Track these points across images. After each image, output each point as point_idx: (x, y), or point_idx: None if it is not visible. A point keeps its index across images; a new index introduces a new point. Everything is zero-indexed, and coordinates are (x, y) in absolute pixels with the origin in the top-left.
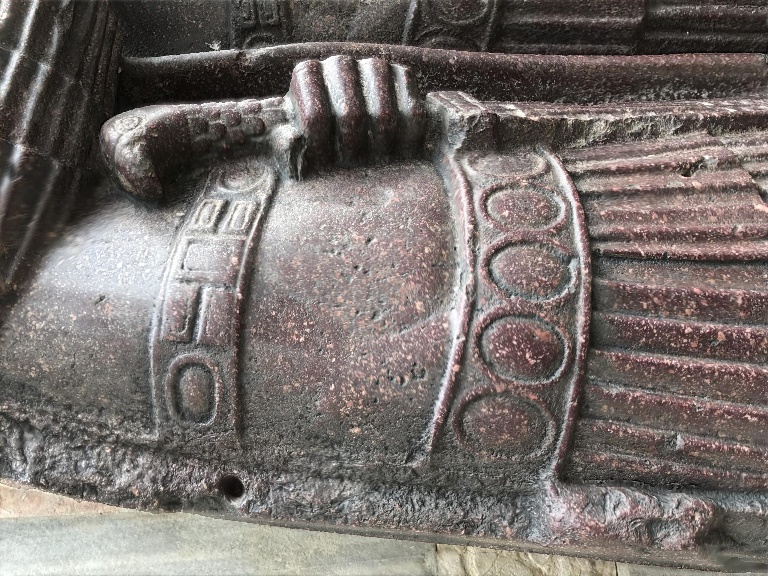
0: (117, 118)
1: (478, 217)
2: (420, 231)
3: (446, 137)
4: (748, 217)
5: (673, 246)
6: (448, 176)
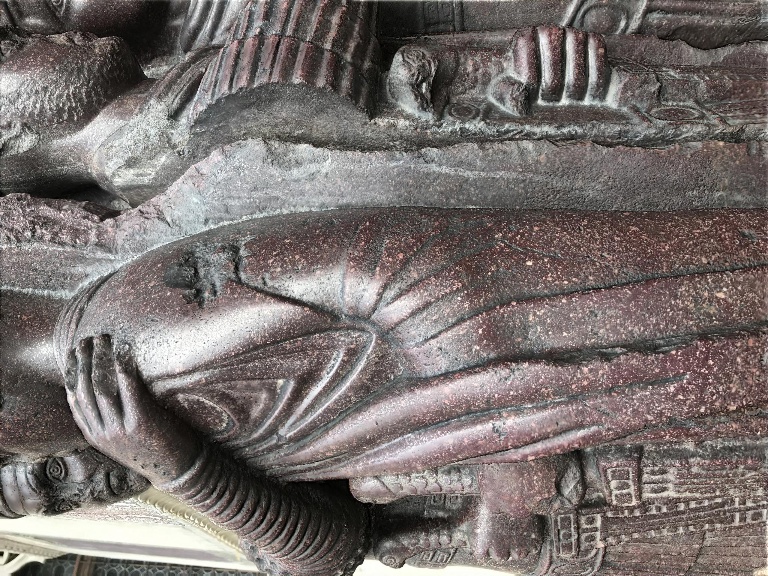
0: (382, 557)
1: (548, 572)
2: (521, 568)
3: (550, 543)
4: (672, 574)
5: (630, 575)
6: (544, 551)
